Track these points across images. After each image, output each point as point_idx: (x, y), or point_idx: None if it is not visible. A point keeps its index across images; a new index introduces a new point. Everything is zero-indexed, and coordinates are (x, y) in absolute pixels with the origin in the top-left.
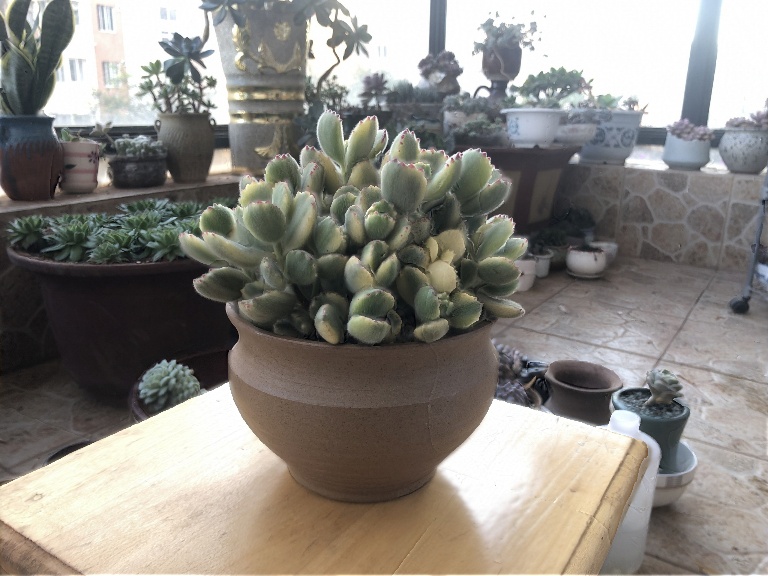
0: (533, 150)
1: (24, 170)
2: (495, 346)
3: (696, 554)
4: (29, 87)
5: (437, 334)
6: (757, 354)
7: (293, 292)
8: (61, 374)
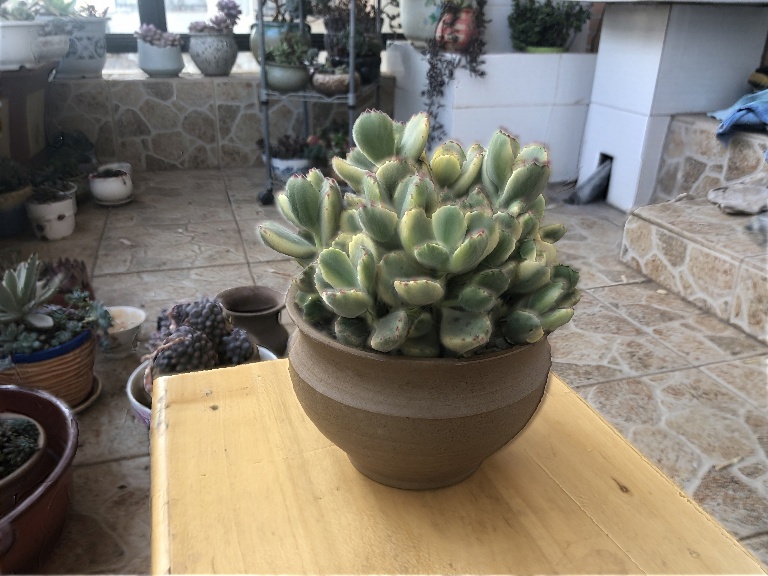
0: (20, 72)
1: None
2: None
3: None
4: None
5: None
6: None
7: None
8: None
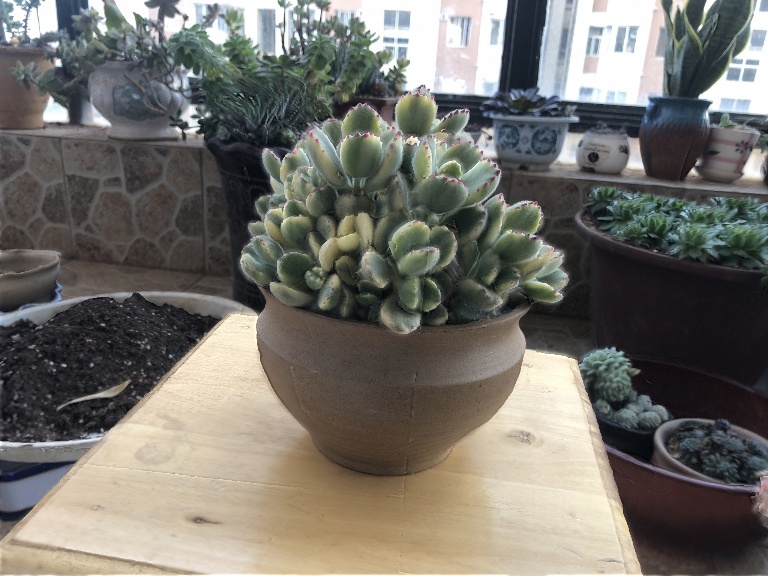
0: None
1: (661, 148)
2: (463, 381)
3: None
4: (693, 70)
5: None
6: None
7: None
8: None
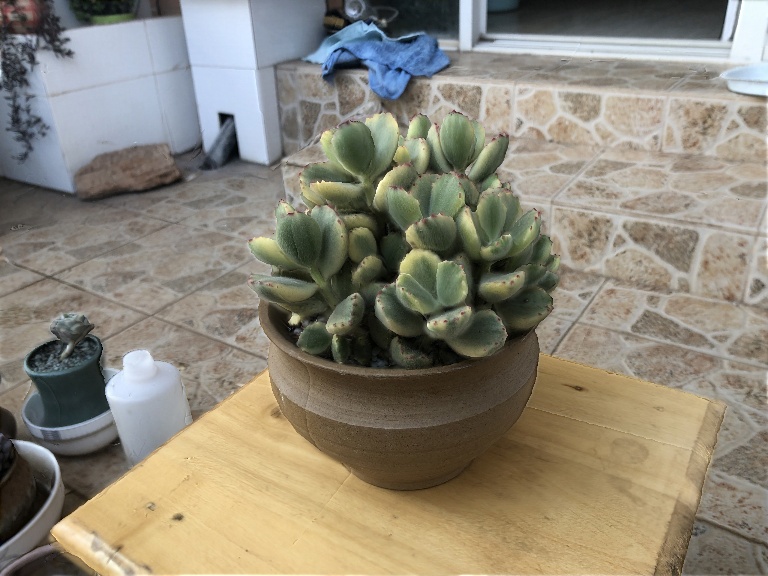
0: None
1: None
2: None
3: None
4: None
5: None
6: None
7: None
8: None
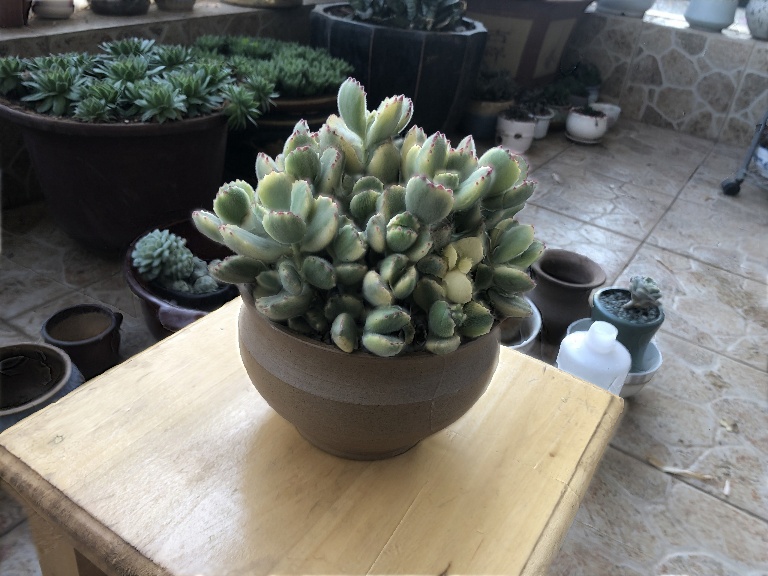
0: None
1: None
2: None
3: (646, 444)
4: None
5: (449, 351)
6: (738, 242)
7: (309, 288)
8: (49, 219)
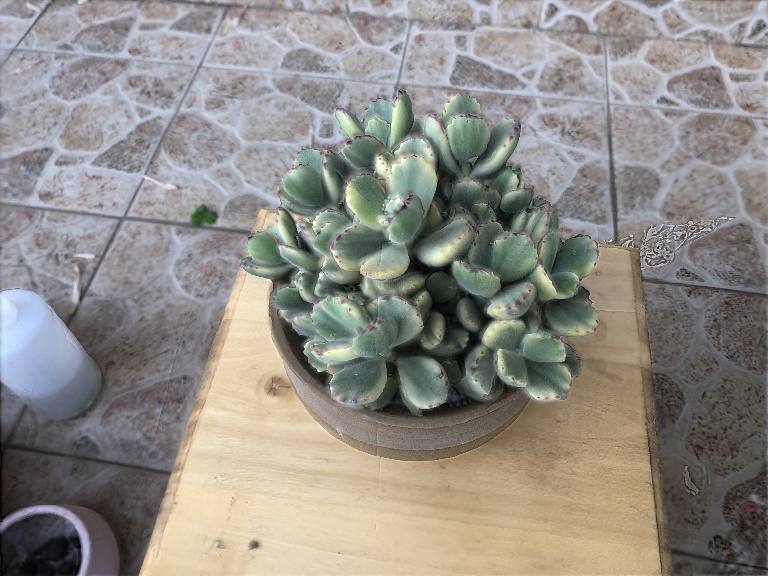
0: None
1: None
2: None
3: None
4: None
5: None
6: None
7: None
8: None
